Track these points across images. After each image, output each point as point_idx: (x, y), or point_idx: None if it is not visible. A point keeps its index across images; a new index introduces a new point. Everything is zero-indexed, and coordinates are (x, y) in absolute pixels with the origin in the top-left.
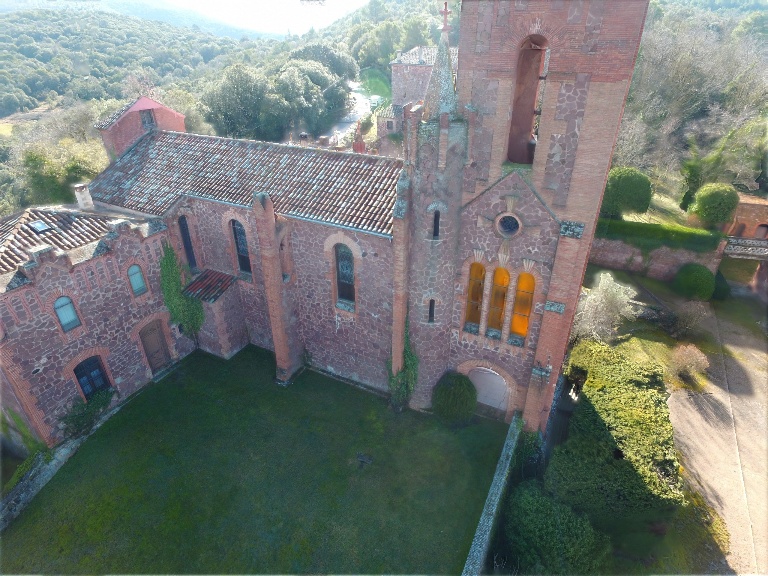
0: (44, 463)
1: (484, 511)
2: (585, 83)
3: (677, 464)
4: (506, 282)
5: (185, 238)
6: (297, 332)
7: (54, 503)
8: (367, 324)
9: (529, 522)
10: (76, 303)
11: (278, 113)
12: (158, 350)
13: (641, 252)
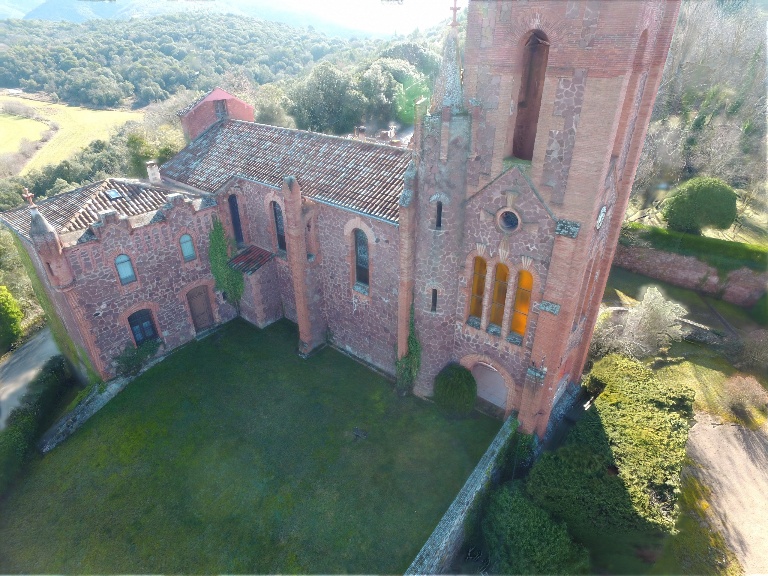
0: (98, 393)
1: (456, 499)
2: (582, 79)
3: (677, 491)
4: (508, 279)
5: (234, 215)
6: (320, 310)
7: (101, 427)
8: (379, 308)
9: (502, 519)
10: (134, 261)
11: (357, 109)
12: (203, 312)
13: (717, 272)
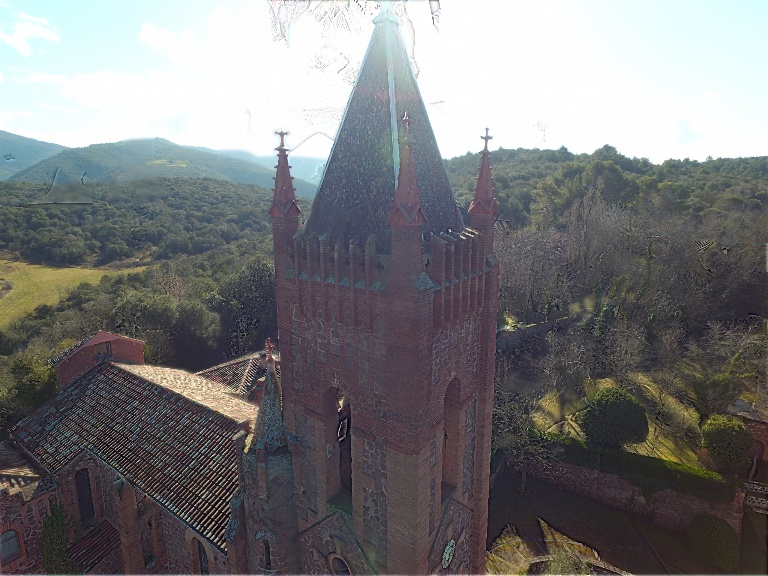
0: None
1: None
2: (383, 446)
3: None
4: None
5: (84, 489)
6: None
7: None
8: None
9: None
10: None
11: None
12: None
13: (642, 492)
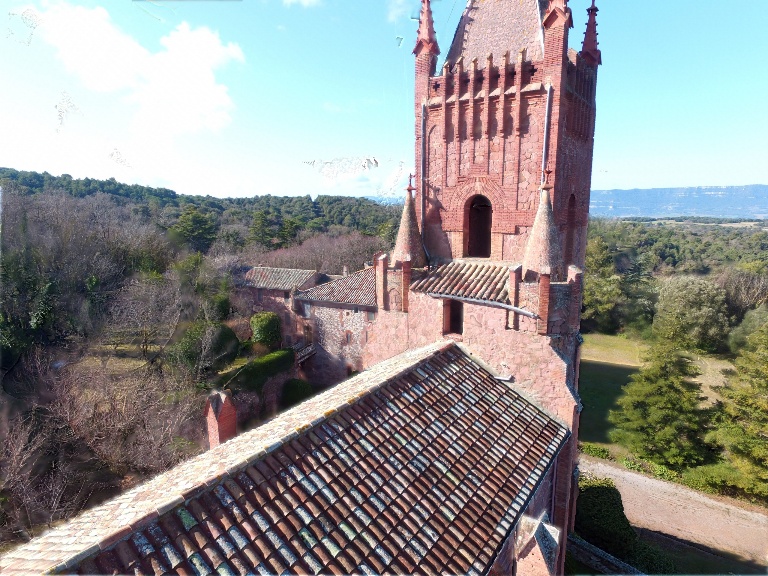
0: None
1: None
2: (580, 228)
3: None
4: None
5: None
6: None
7: None
8: None
9: None
10: None
11: None
12: None
13: (256, 393)
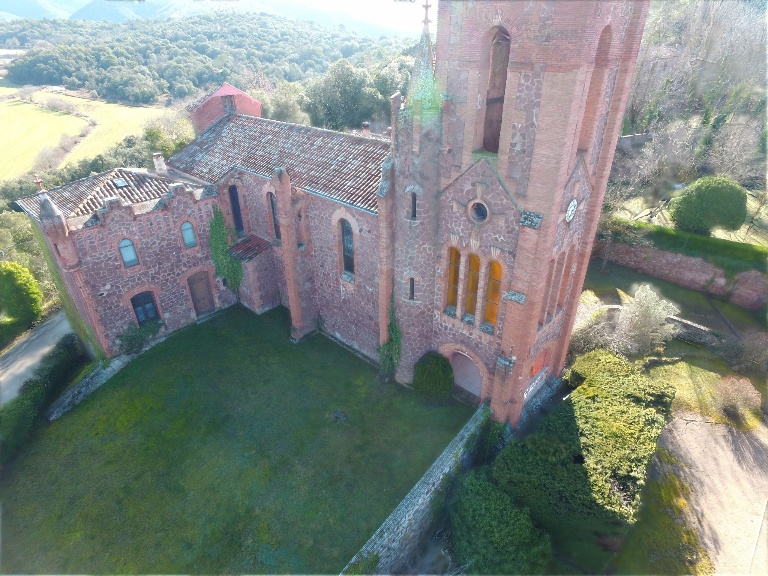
0: (102, 368)
1: (421, 479)
2: (541, 73)
3: (641, 483)
4: None
5: (235, 205)
6: (312, 297)
7: (103, 399)
8: (364, 296)
9: (466, 501)
10: (136, 246)
11: (372, 106)
12: (204, 297)
13: (725, 274)
